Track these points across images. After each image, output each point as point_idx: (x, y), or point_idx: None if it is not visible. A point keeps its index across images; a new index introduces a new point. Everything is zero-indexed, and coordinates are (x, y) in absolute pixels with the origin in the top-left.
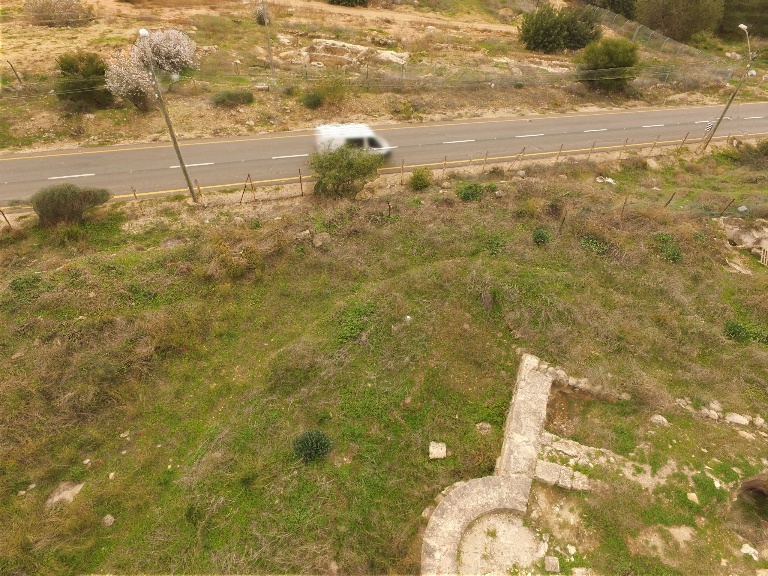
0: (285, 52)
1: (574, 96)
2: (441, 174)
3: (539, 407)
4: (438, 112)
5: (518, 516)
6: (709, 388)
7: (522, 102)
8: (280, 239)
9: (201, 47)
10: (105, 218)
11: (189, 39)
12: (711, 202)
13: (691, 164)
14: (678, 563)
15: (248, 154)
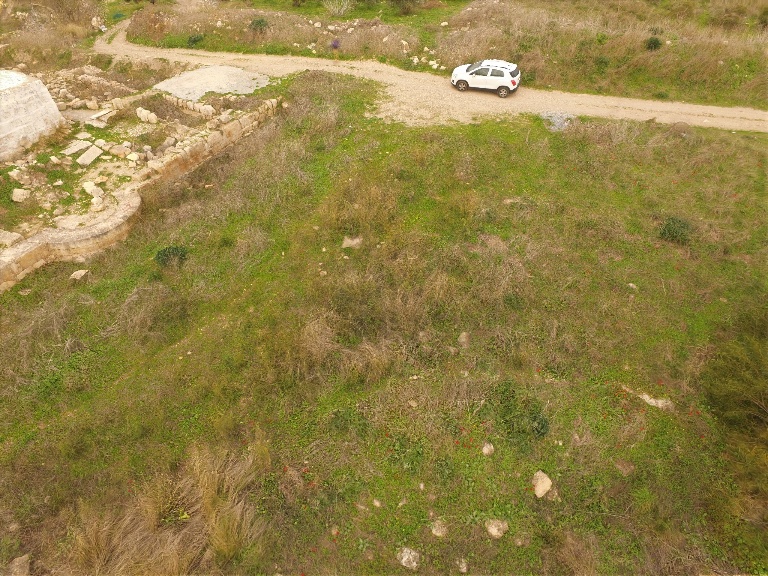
0: None
1: None
2: None
3: None
4: None
5: None
6: None
7: None
8: (93, 571)
9: None
10: None
11: None
12: None
13: None
14: None
15: None
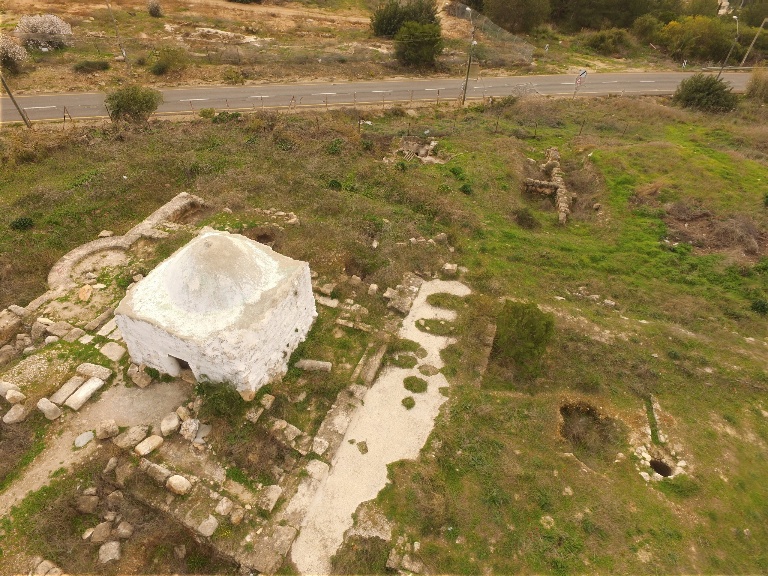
0: (164, 37)
1: (389, 69)
2: None
3: None
4: (264, 79)
5: (124, 250)
6: (285, 205)
7: (341, 73)
8: None
9: (89, 32)
10: None
11: (63, 22)
12: (407, 128)
13: (440, 113)
14: None
15: (86, 102)
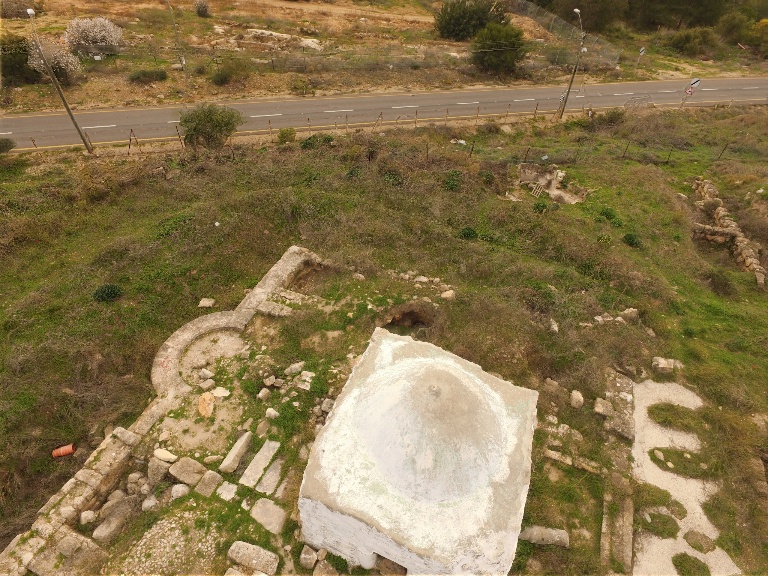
0: (216, 40)
1: (466, 76)
2: (310, 135)
3: (283, 273)
4: (334, 89)
5: (238, 332)
6: (420, 265)
7: (415, 81)
8: (139, 173)
9: (137, 35)
10: (11, 163)
11: (115, 26)
12: (521, 153)
13: (539, 129)
14: (323, 349)
15: (148, 119)
